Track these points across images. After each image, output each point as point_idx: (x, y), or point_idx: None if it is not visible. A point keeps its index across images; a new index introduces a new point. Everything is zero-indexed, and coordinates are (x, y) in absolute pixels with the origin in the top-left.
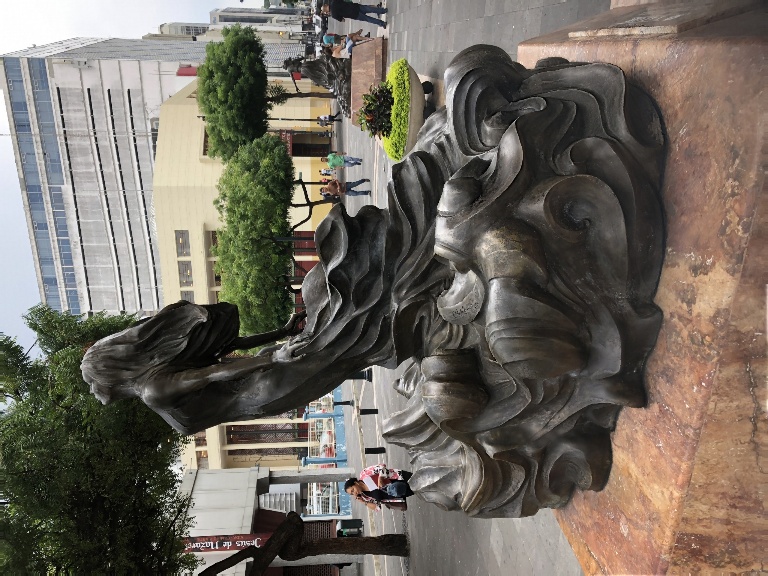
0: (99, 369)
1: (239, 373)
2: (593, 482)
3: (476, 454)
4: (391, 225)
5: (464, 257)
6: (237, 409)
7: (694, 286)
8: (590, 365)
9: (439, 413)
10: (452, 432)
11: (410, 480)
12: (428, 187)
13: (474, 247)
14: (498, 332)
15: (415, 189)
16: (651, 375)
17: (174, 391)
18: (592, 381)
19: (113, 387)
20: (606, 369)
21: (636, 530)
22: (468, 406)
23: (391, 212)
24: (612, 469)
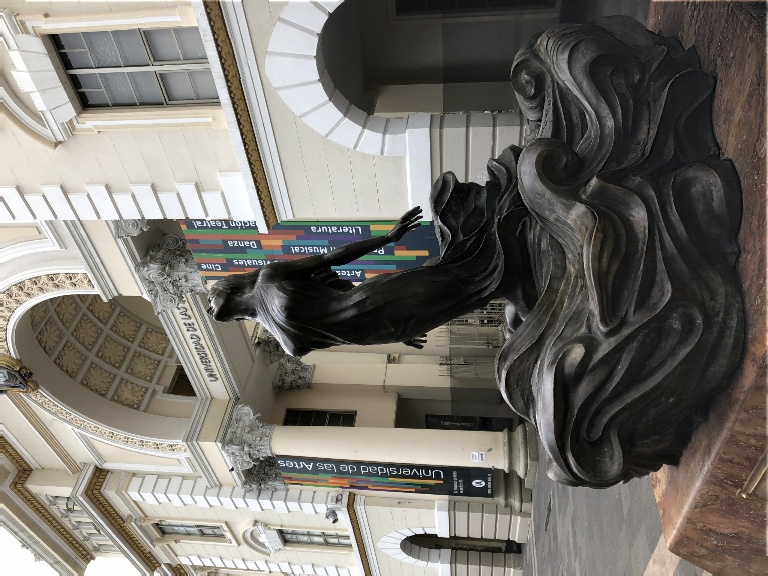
0: (226, 280)
1: (351, 246)
2: (721, 179)
3: (584, 207)
4: (490, 180)
5: (528, 54)
6: (339, 301)
7: (691, 1)
8: (647, 68)
9: (531, 151)
10: (552, 187)
11: (536, 392)
12: (516, 150)
13: (533, 47)
14: (556, 45)
15: (506, 155)
16: (707, 68)
17: (288, 264)
18: (658, 85)
19: (231, 294)
20: (658, 58)
21: (763, 116)
22: (557, 142)
23: (490, 174)
24: (734, 163)
